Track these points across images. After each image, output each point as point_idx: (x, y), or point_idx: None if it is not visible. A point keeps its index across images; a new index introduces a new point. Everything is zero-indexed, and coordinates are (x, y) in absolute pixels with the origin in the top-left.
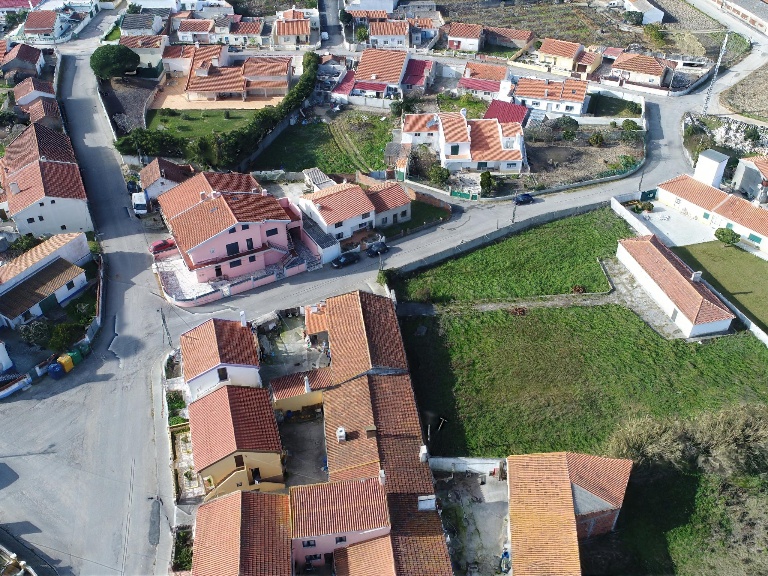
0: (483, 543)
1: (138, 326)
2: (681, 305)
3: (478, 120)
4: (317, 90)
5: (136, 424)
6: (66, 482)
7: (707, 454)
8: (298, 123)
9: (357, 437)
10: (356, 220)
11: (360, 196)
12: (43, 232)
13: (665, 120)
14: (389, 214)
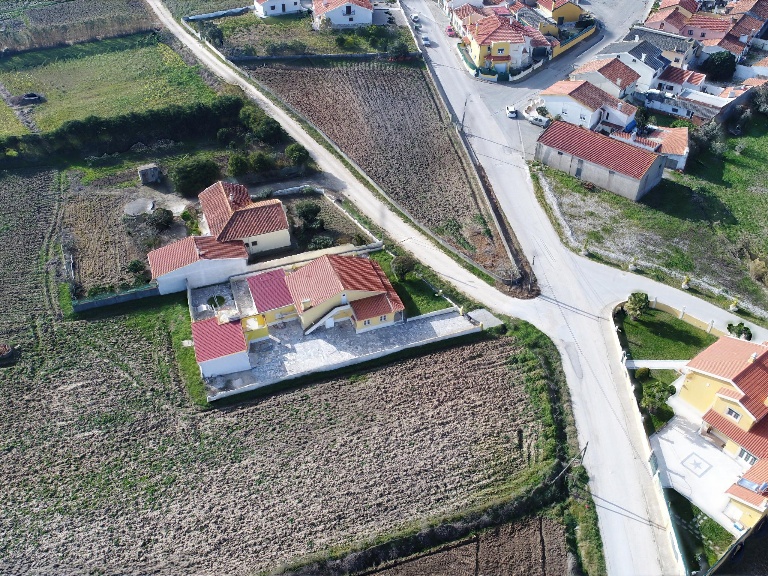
0: None
1: None
2: None
3: None
4: None
5: (638, 7)
6: (607, 9)
7: None
8: None
9: None
10: None
11: None
12: None
13: None
14: None
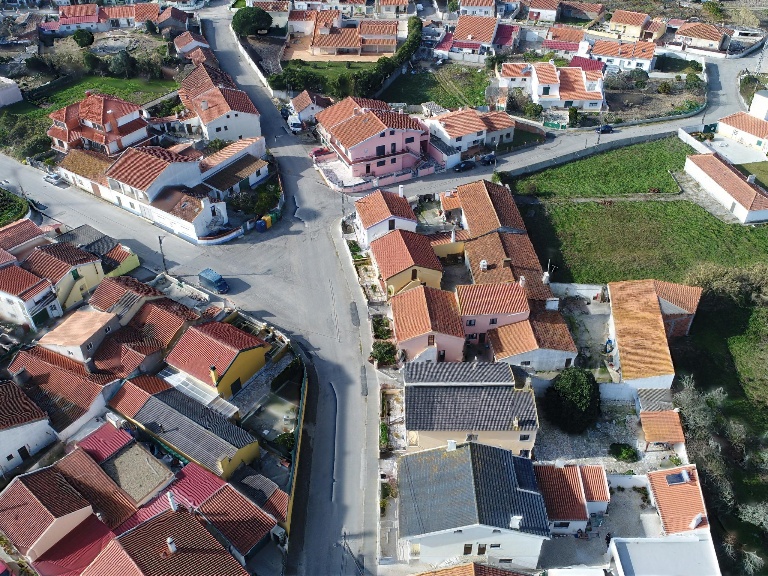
0: (592, 337)
1: (313, 202)
2: (739, 198)
3: (565, 68)
4: (422, 47)
5: (327, 260)
6: (285, 290)
7: (759, 291)
8: (408, 72)
9: (495, 267)
10: (472, 137)
11: (475, 118)
12: (227, 139)
13: (723, 76)
14: (497, 134)
